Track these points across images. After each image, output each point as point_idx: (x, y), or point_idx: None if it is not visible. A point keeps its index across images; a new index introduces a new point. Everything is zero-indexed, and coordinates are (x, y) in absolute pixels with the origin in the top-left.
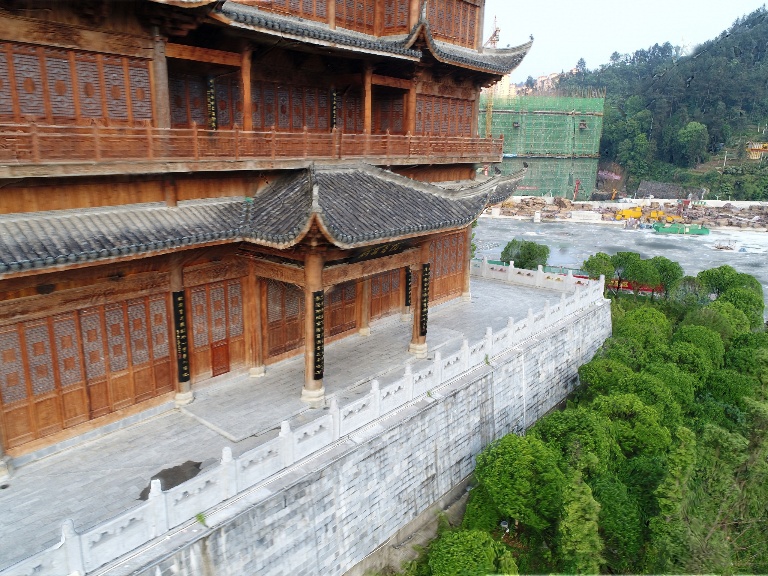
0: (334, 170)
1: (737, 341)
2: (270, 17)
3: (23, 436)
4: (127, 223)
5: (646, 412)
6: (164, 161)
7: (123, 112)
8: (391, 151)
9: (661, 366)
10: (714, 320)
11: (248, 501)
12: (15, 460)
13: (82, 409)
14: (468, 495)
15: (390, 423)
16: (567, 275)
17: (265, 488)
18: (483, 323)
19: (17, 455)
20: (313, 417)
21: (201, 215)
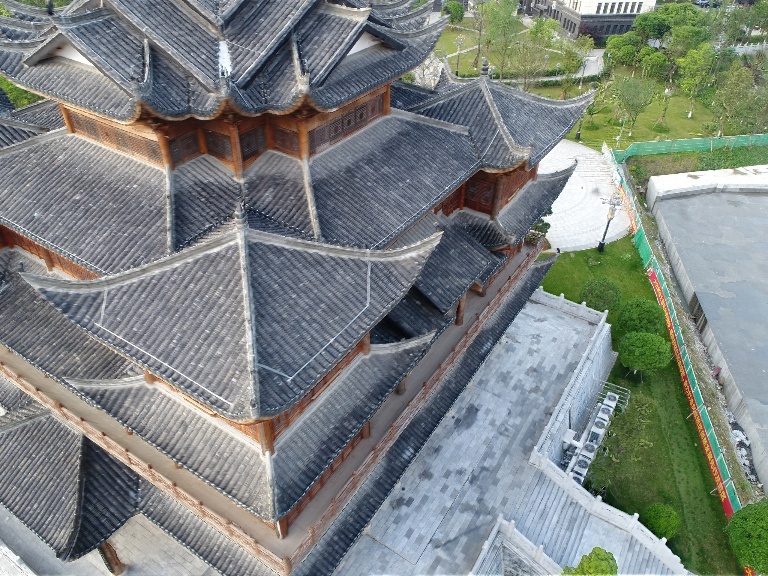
0: (64, 423)
1: None
2: None
3: None
4: None
5: None
6: None
7: None
8: None
9: None
10: None
11: None
12: None
13: None
14: None
15: (3, 563)
16: None
17: None
18: None
19: None
20: None
21: None
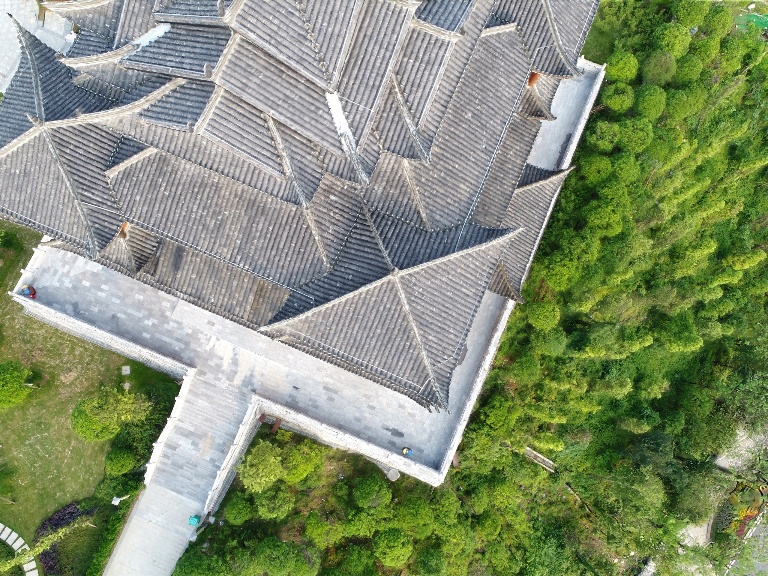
0: None
1: (677, 62)
2: None
3: None
4: None
5: (614, 220)
6: None
7: None
8: None
9: (626, 163)
10: (667, 68)
11: (491, 355)
12: None
13: None
14: (531, 265)
15: None
16: (580, 59)
17: (493, 347)
18: (532, 153)
19: None
20: (487, 296)
21: None
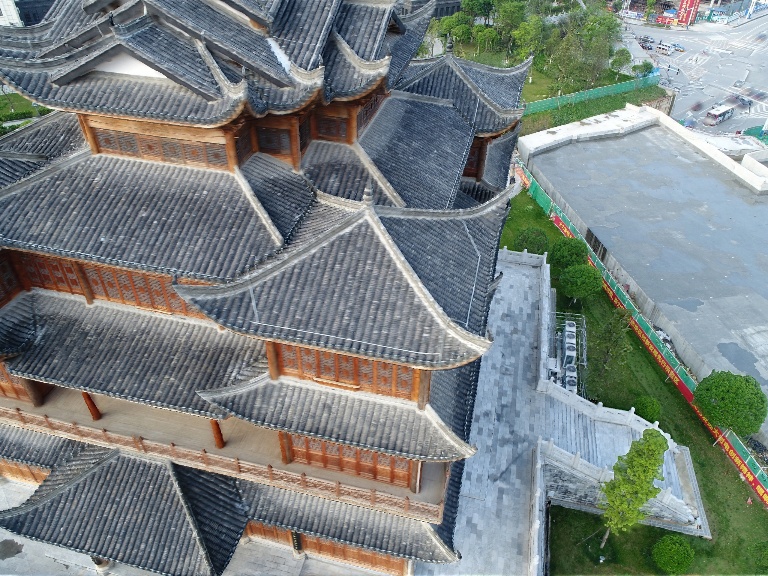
0: (140, 458)
1: None
2: (144, 318)
3: (8, 473)
4: (9, 430)
5: None
6: (5, 420)
7: (5, 379)
8: (213, 463)
9: None
10: None
11: None
12: (7, 479)
13: (32, 477)
14: None
15: None
16: None
17: None
18: None
19: (8, 478)
20: None
21: (52, 440)
